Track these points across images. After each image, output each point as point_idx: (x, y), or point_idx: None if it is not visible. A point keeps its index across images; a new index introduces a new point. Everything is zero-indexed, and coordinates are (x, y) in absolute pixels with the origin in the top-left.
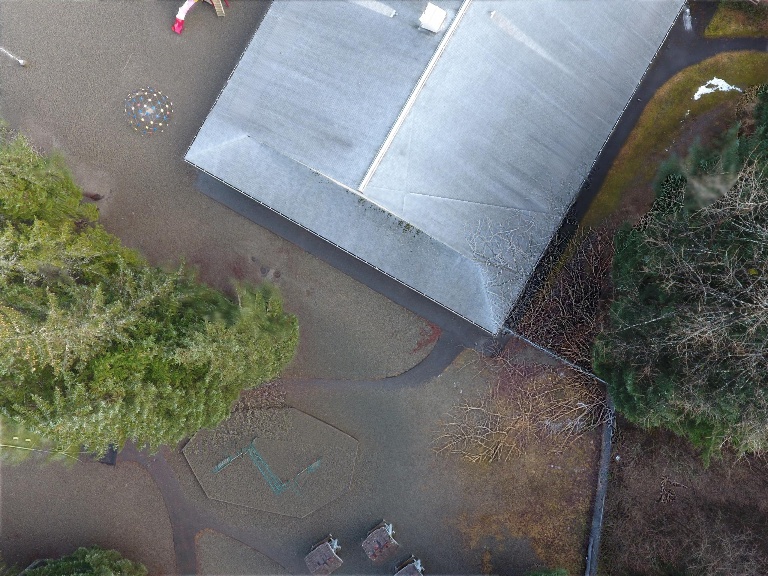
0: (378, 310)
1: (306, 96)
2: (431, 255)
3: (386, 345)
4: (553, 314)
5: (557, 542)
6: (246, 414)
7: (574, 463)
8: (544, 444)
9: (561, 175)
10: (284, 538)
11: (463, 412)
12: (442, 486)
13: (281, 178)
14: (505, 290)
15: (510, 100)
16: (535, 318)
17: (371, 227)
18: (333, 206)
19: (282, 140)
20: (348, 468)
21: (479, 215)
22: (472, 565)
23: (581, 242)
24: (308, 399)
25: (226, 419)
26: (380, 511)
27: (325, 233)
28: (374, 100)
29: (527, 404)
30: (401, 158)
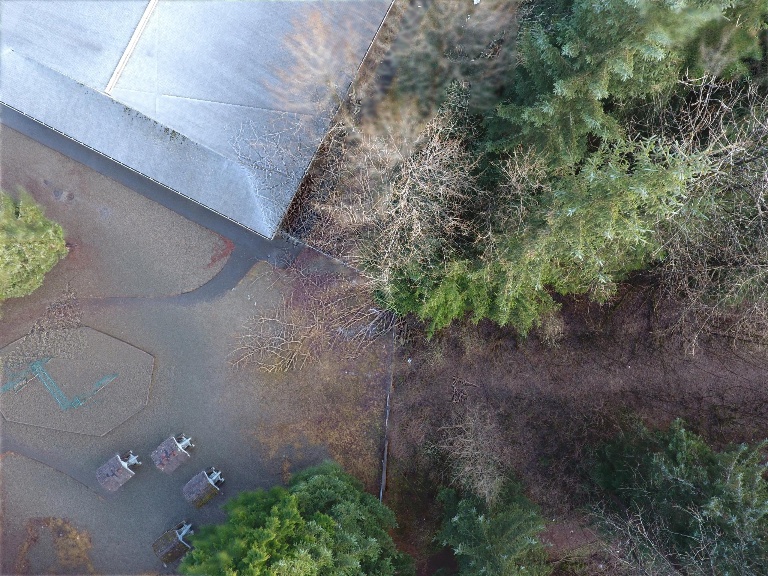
0: (171, 227)
1: (63, 6)
2: (199, 161)
3: (180, 261)
4: (343, 223)
5: (354, 447)
6: (41, 335)
7: (367, 368)
8: (338, 351)
9: (326, 77)
10: (86, 457)
11: (258, 324)
12: (239, 398)
13: (49, 92)
14: (276, 194)
15: (263, 0)
16: (326, 227)
17: (140, 136)
18: (101, 117)
19: (41, 51)
20: (144, 384)
21: (240, 117)
22: (272, 474)
23: (368, 150)
24: (104, 318)
25: (21, 341)
26: (179, 425)
27: (98, 146)
28: (122, 3)
29: (320, 313)
30: (149, 59)
